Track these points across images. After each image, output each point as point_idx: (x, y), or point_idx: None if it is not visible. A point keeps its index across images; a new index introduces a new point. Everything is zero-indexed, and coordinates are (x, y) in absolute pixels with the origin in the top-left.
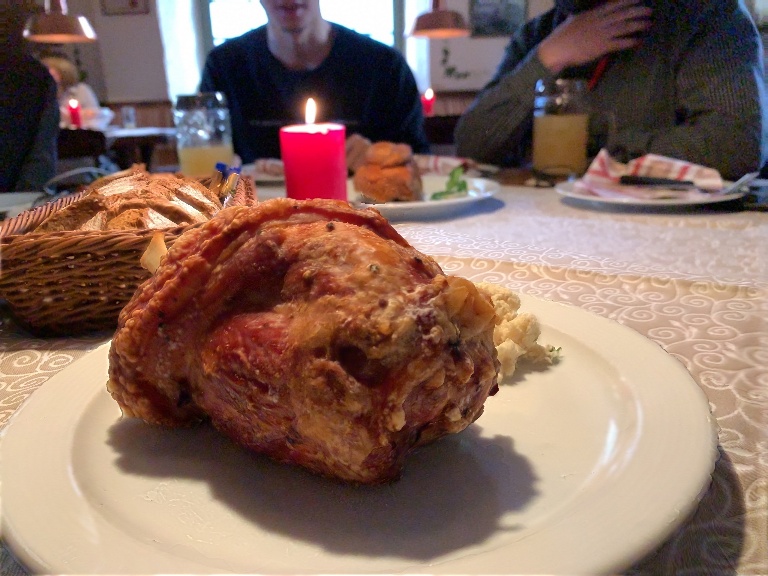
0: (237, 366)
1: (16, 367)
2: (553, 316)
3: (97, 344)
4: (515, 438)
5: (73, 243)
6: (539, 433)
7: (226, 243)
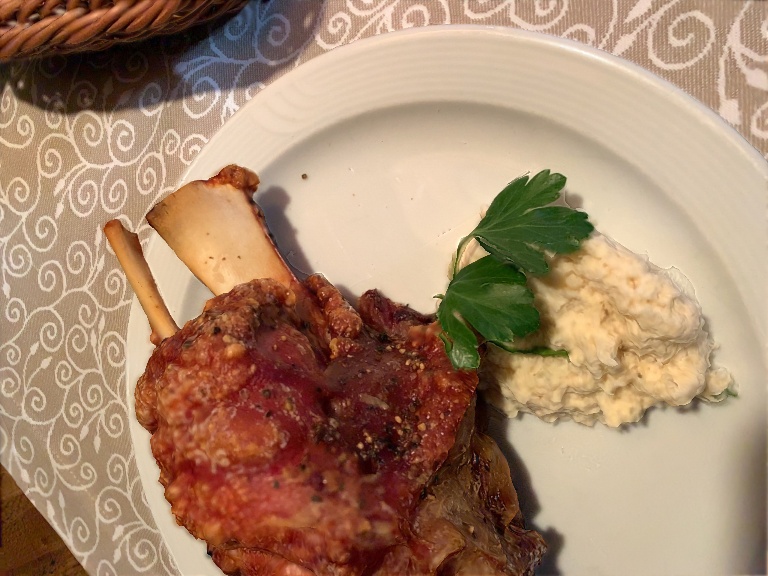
0: None
1: (90, 147)
2: None
3: (146, 90)
4: (567, 542)
5: (14, 51)
6: (600, 542)
7: None
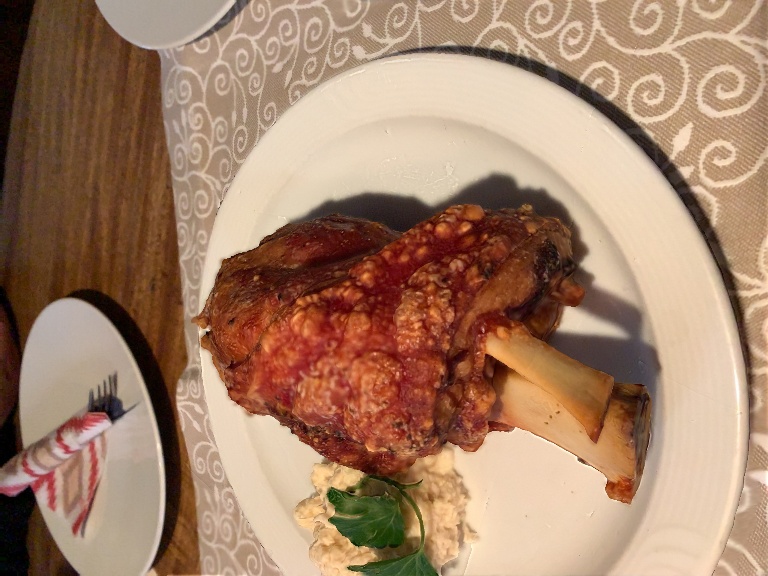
0: (337, 224)
1: None
2: (315, 574)
3: None
4: None
5: None
6: None
7: (320, 289)
